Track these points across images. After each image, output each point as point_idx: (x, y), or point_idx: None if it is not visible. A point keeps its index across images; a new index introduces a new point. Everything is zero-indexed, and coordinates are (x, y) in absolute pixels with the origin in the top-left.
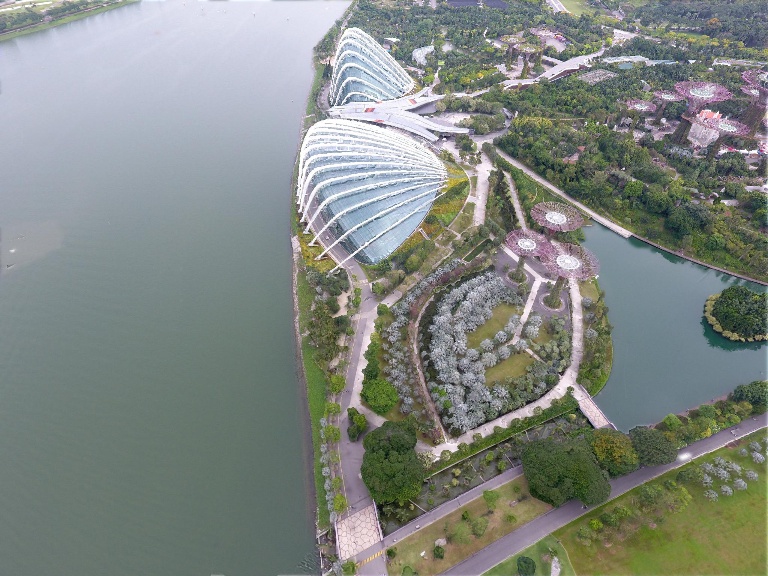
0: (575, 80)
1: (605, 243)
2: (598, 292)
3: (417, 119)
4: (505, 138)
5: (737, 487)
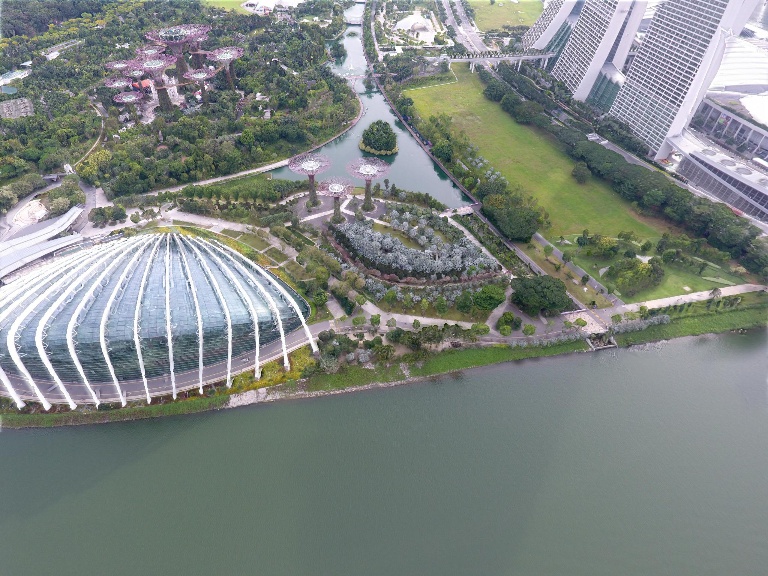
0: (20, 119)
1: (291, 176)
2: (355, 187)
3: (10, 246)
4: (121, 183)
5: (500, 175)
